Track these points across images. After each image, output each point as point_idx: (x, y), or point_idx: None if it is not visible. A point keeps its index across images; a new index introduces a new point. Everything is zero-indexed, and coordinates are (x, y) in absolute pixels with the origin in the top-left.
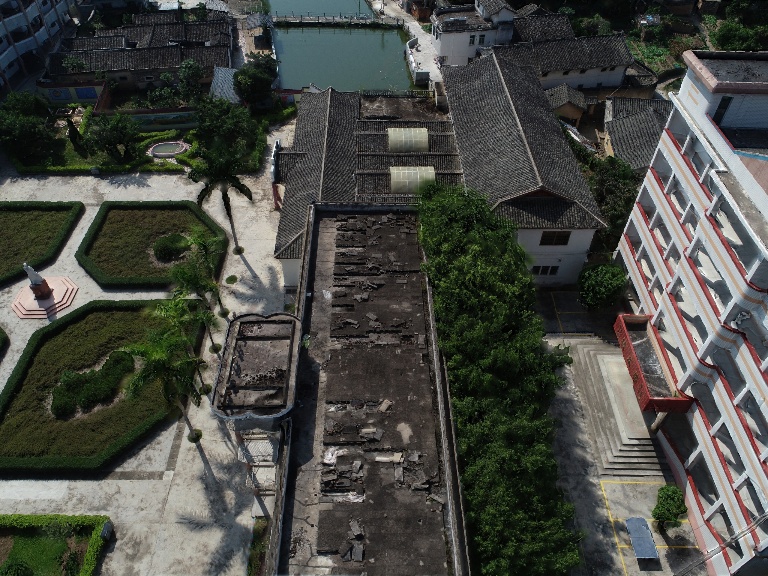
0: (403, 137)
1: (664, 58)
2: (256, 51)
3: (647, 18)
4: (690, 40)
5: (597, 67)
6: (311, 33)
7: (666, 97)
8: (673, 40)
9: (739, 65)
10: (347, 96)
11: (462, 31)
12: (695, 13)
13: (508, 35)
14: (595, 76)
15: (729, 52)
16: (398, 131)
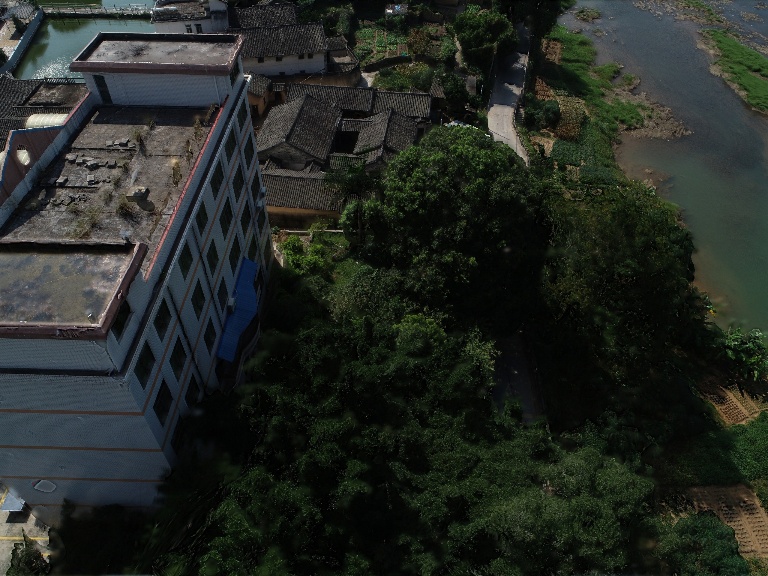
0: (40, 122)
1: (396, 47)
2: (9, 41)
3: (395, 8)
4: (435, 29)
5: (289, 55)
6: (88, 24)
7: (370, 84)
8: (416, 29)
9: (138, 46)
10: (22, 83)
11: (174, 20)
12: (465, 3)
13: (224, 24)
14: (294, 64)
15: (136, 34)
16: (39, 116)
